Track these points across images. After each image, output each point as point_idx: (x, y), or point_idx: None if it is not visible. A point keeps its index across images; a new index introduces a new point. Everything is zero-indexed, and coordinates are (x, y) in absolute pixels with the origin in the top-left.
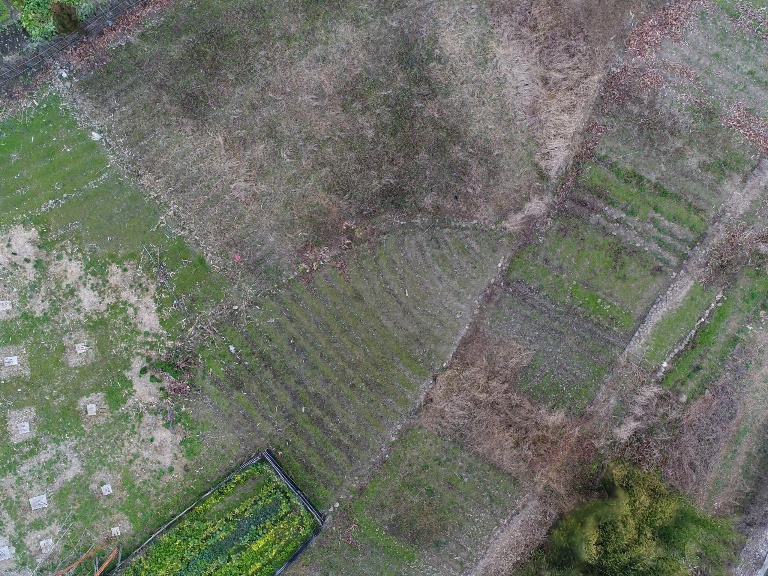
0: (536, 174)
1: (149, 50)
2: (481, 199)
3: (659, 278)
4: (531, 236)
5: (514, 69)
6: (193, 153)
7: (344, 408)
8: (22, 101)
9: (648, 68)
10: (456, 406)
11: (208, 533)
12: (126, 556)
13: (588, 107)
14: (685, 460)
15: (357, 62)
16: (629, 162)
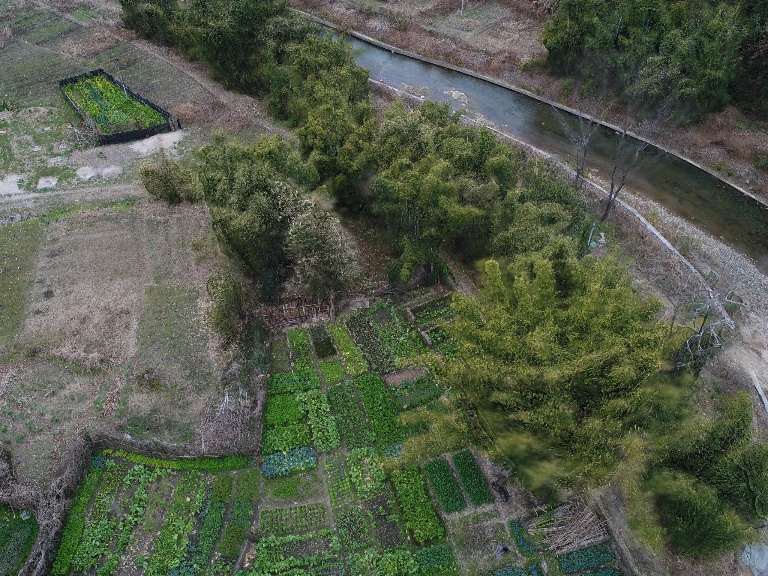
0: None
1: None
2: None
3: None
4: None
5: None
6: None
7: None
8: None
9: None
10: None
11: None
12: None
13: None
14: None
15: None
16: None
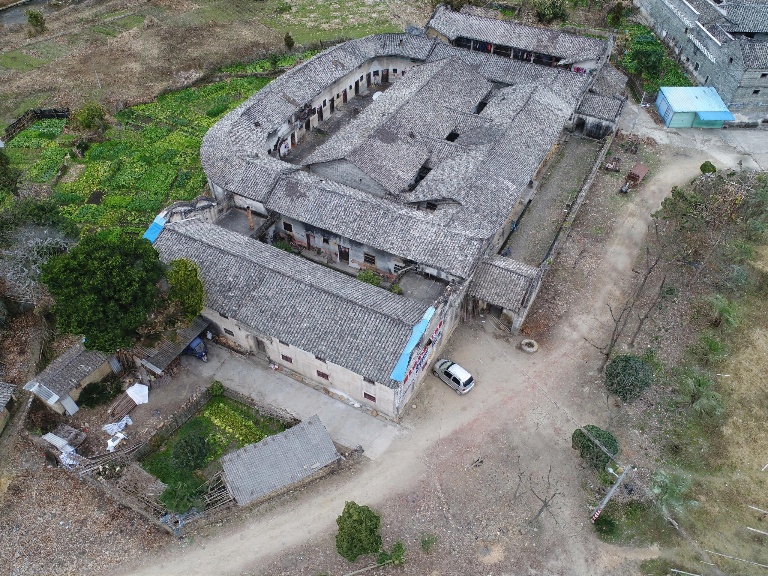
0: None
1: None
2: None
3: None
4: None
5: None
6: None
7: None
8: None
9: None
10: (194, 6)
11: None
12: None
13: None
14: (128, 1)
15: None
16: None
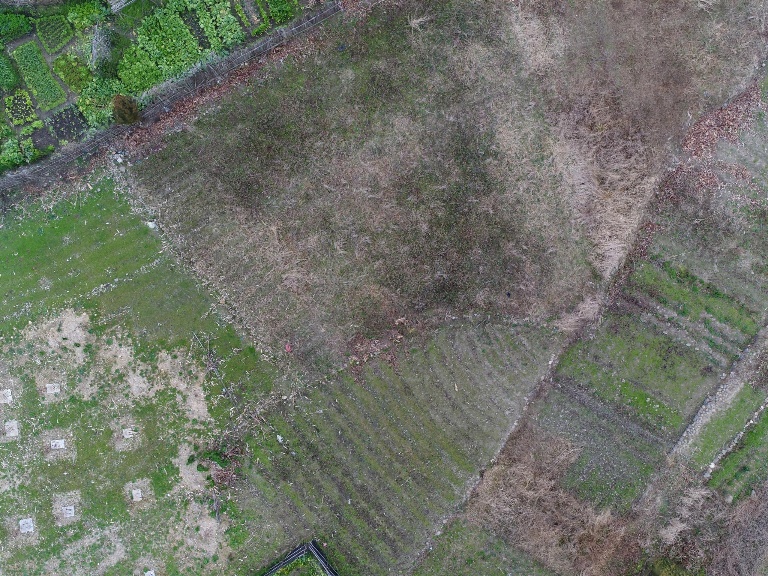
0: (589, 273)
1: (205, 137)
2: (534, 296)
3: (709, 379)
4: (582, 333)
5: (570, 167)
6: (246, 241)
7: (390, 501)
8: (76, 184)
9: (704, 168)
10: (502, 502)
11: None
12: None
13: (643, 206)
14: (730, 561)
15: (413, 155)
16: (682, 262)
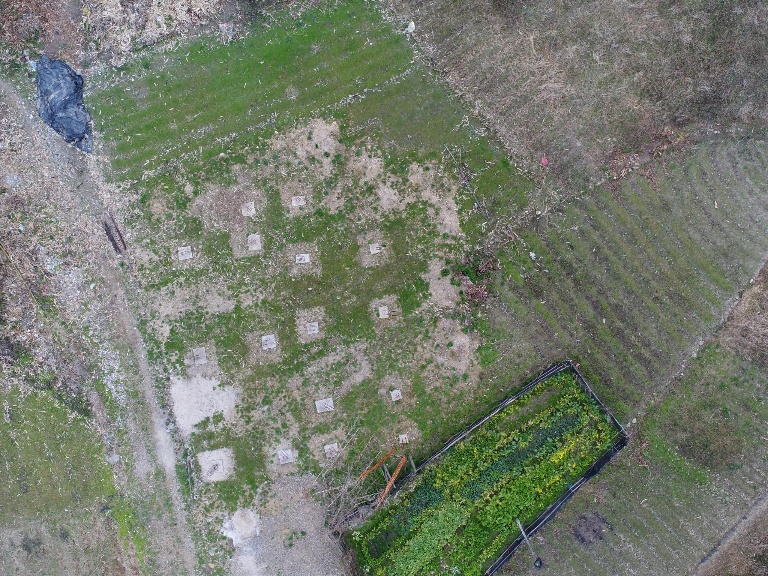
0: None
1: None
2: None
3: None
4: None
5: None
6: (501, 52)
7: (646, 321)
8: None
9: None
10: (761, 324)
11: (500, 444)
12: (418, 463)
13: None
14: None
15: None
16: None
